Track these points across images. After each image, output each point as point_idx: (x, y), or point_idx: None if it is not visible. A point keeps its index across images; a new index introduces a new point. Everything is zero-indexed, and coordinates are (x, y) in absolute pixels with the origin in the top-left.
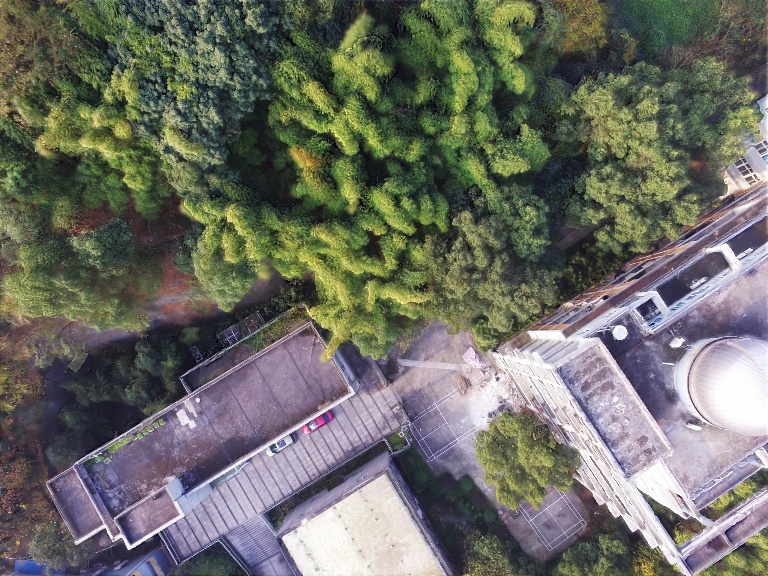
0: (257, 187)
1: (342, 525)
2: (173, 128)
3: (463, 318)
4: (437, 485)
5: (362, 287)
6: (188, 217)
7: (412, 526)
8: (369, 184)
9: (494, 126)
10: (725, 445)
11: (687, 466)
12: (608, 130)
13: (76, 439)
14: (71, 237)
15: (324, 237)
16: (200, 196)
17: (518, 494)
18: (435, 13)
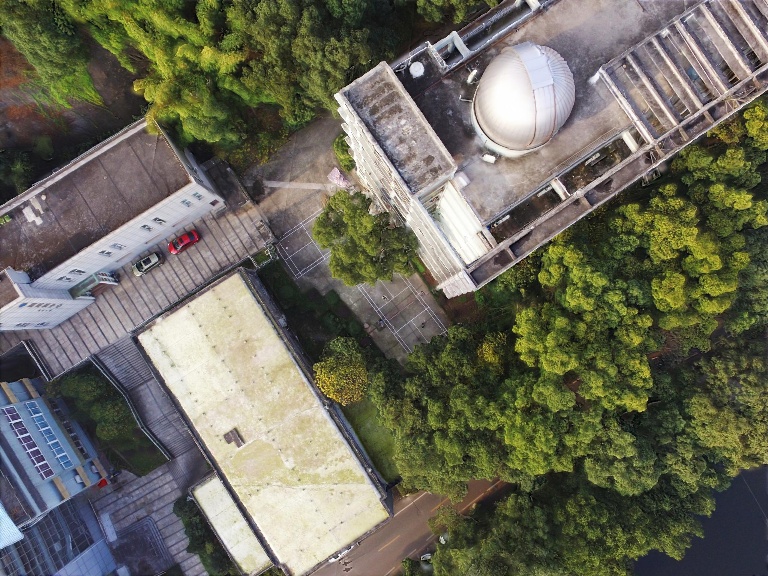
0: None
1: (196, 322)
2: None
3: (283, 84)
4: (303, 300)
5: None
6: None
7: (265, 322)
8: None
9: None
10: (520, 177)
11: (484, 198)
12: None
13: None
14: None
15: None
16: None
17: (354, 272)
18: None
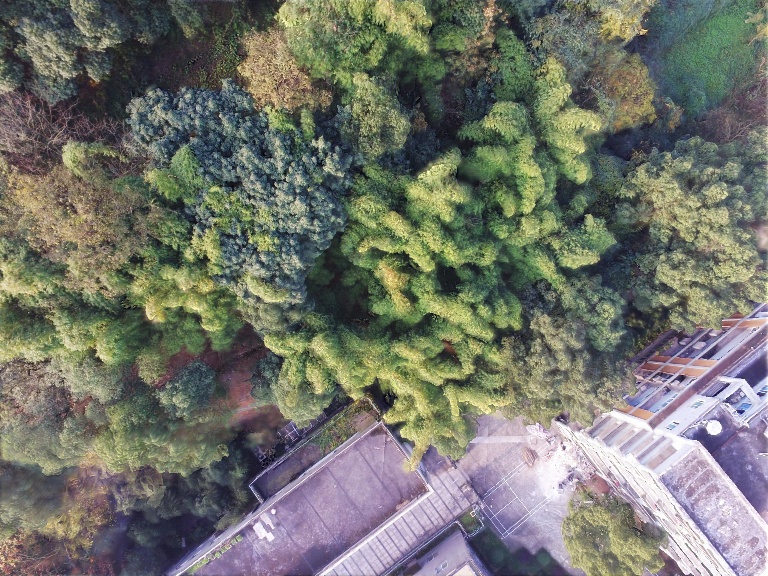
0: (327, 305)
1: None
2: (255, 278)
3: (544, 415)
4: (514, 562)
5: (438, 392)
6: (252, 334)
7: None
8: (441, 293)
9: (559, 220)
10: None
11: None
12: (674, 214)
13: (148, 558)
14: (155, 392)
15: (404, 356)
16: (280, 333)
17: None
18: (501, 126)
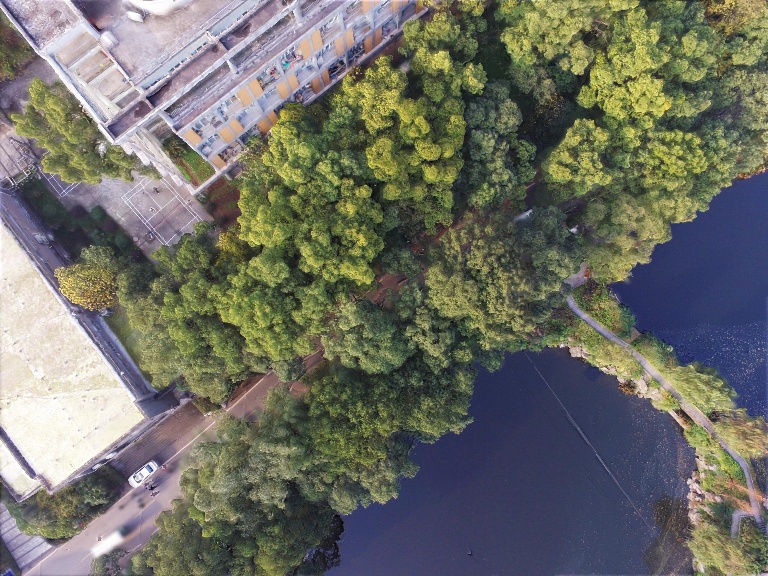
0: None
1: None
2: None
3: None
4: (68, 218)
5: None
6: None
7: (5, 233)
8: None
9: None
10: (172, 34)
11: (135, 57)
12: None
13: None
14: None
15: None
16: None
17: (69, 166)
18: None
